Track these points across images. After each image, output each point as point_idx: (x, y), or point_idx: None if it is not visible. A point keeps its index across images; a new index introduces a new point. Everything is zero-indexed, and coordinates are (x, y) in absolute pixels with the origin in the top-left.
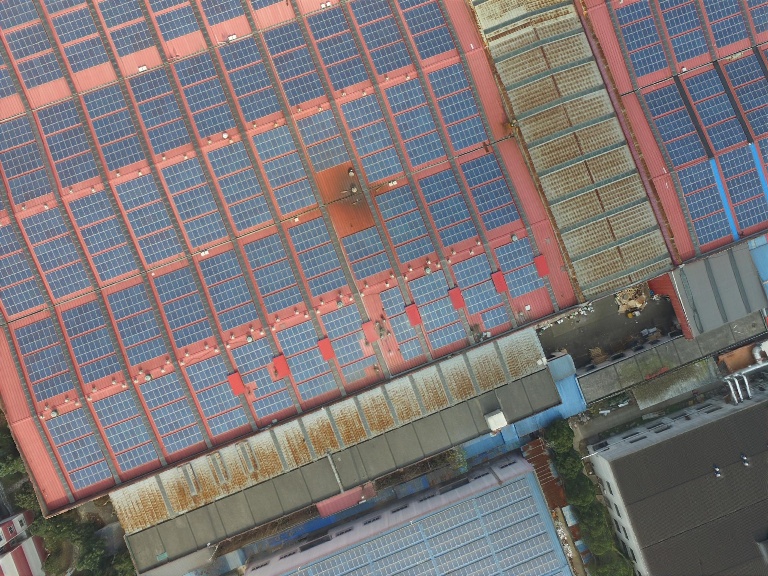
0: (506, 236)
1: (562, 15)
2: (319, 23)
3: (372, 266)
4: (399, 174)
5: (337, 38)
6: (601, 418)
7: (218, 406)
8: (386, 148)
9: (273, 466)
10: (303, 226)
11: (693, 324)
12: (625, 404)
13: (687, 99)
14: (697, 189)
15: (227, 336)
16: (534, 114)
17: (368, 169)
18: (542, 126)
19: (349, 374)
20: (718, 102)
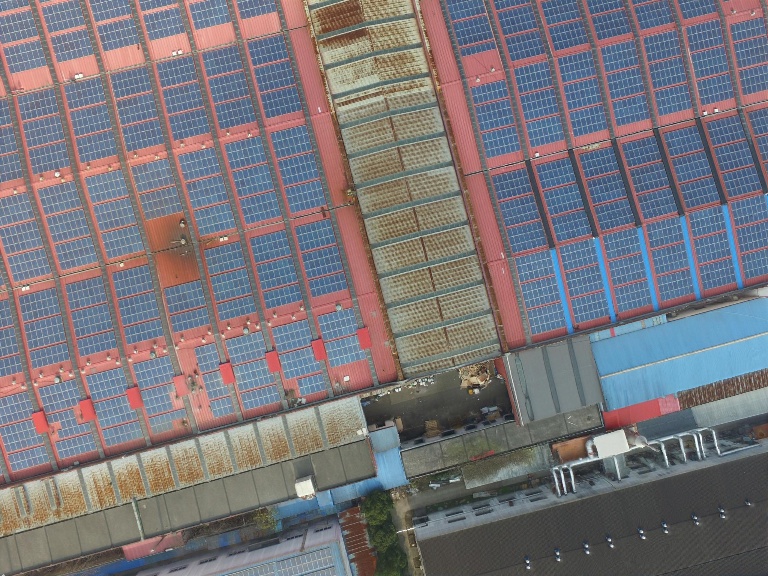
0: (331, 304)
1: (417, 87)
2: (168, 70)
3: (191, 320)
4: (232, 230)
5: (184, 87)
6: (431, 491)
7: (20, 442)
8: (221, 203)
9: (77, 506)
10: (128, 272)
11: (524, 411)
12: (456, 480)
13: (536, 185)
14: (534, 278)
15: (36, 374)
16: (376, 184)
17: (200, 222)
18: (382, 197)
19: (156, 425)
20: (567, 192)
